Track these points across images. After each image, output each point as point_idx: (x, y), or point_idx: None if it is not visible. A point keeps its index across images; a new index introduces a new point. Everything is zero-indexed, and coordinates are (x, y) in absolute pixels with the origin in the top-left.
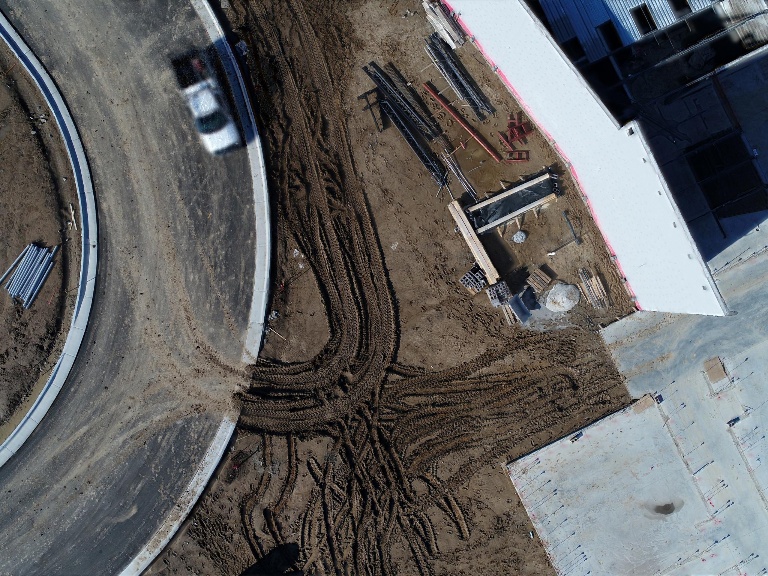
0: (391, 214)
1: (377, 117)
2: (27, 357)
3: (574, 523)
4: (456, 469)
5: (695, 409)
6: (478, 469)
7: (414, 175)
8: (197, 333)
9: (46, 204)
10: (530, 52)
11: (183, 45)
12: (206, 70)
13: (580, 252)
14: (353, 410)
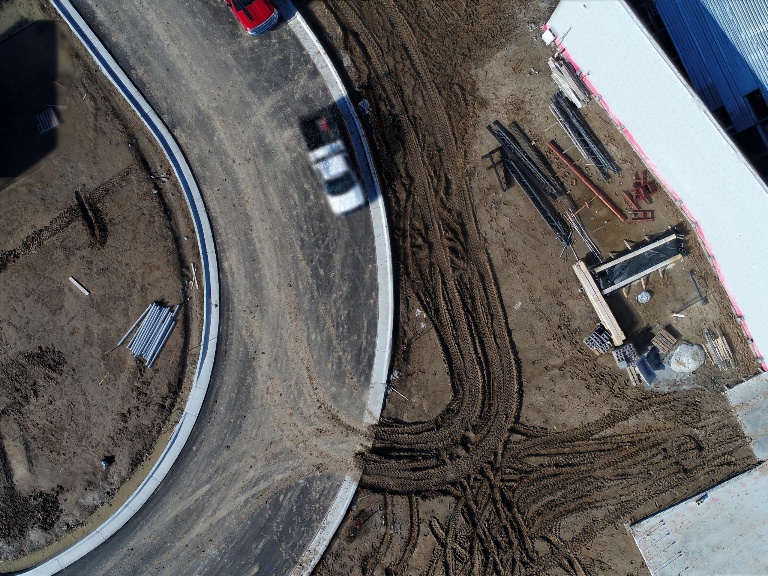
0: (514, 274)
1: (501, 176)
2: (149, 416)
3: None
4: (579, 530)
5: None
6: (602, 530)
7: (538, 235)
8: (319, 393)
9: (168, 263)
10: (676, 121)
11: (305, 104)
12: (328, 129)
13: (705, 312)
14: (475, 470)
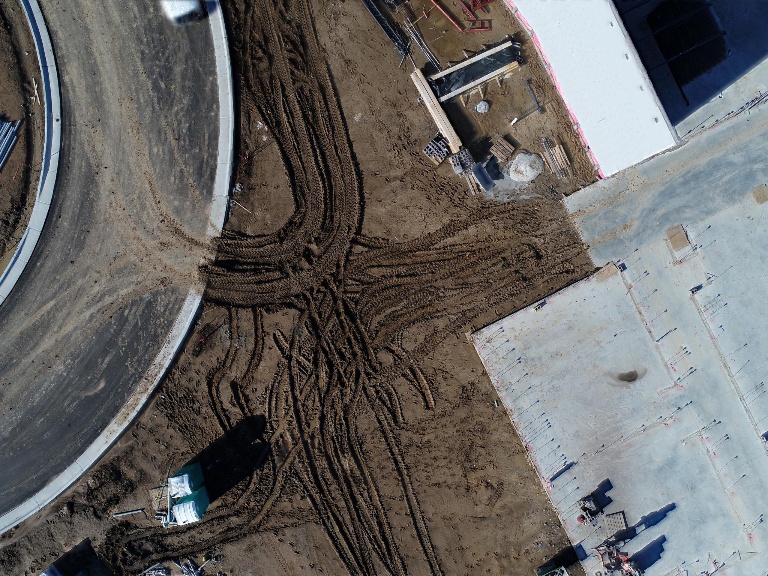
0: (354, 85)
1: None
2: None
3: (538, 391)
4: (421, 339)
5: (658, 277)
6: (443, 339)
7: (377, 45)
8: (162, 206)
9: (9, 78)
10: None
11: None
12: None
13: (543, 121)
14: (318, 282)
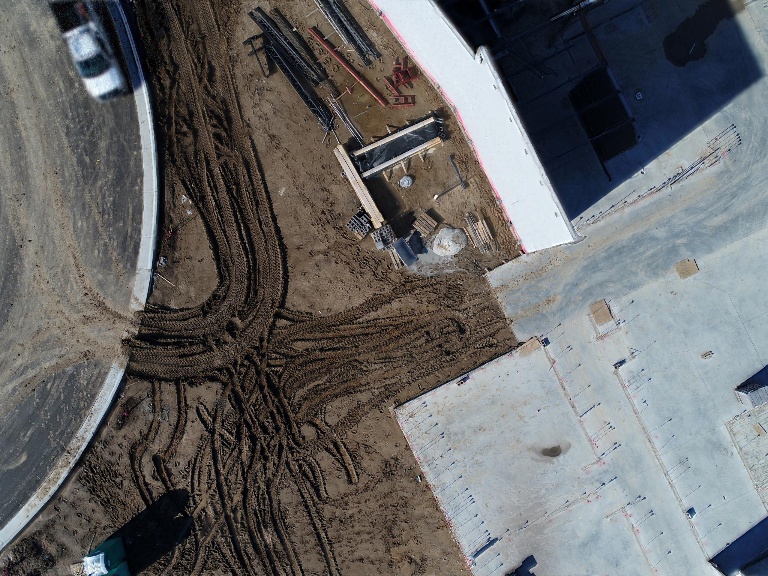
0: (278, 159)
1: (263, 63)
2: None
3: (461, 466)
4: (344, 413)
5: (581, 352)
6: (366, 413)
7: (300, 120)
8: (85, 280)
9: None
10: None
11: None
12: (93, 17)
13: (466, 196)
14: (242, 356)
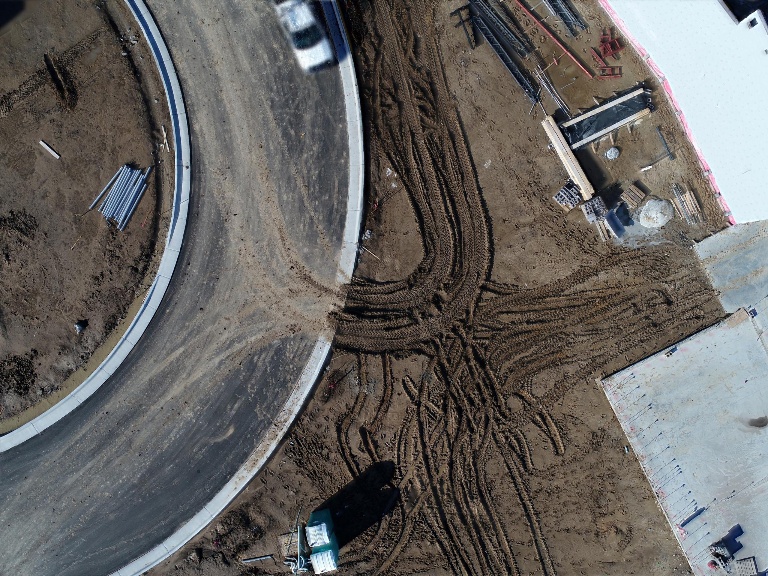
0: (484, 132)
1: (470, 34)
2: (122, 279)
3: (669, 437)
4: (551, 385)
5: None
6: (573, 385)
7: (507, 92)
8: (291, 253)
9: (138, 126)
10: None
11: None
12: None
13: (674, 167)
14: (447, 328)
